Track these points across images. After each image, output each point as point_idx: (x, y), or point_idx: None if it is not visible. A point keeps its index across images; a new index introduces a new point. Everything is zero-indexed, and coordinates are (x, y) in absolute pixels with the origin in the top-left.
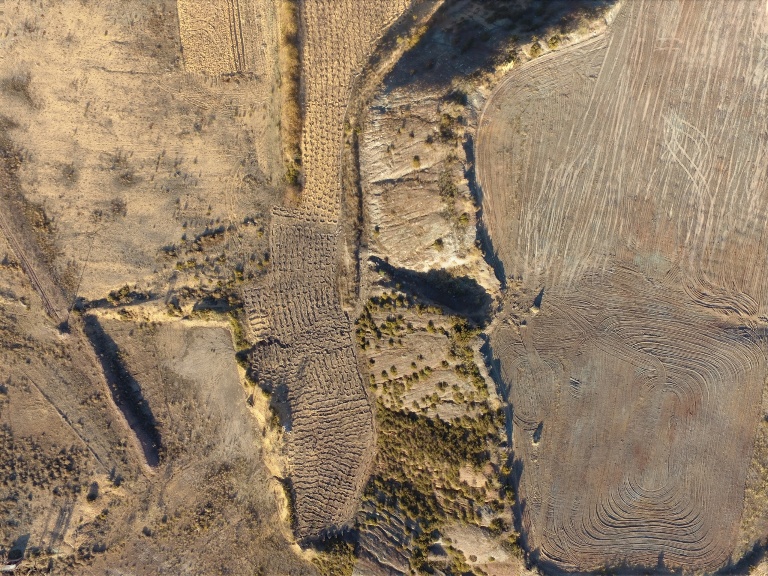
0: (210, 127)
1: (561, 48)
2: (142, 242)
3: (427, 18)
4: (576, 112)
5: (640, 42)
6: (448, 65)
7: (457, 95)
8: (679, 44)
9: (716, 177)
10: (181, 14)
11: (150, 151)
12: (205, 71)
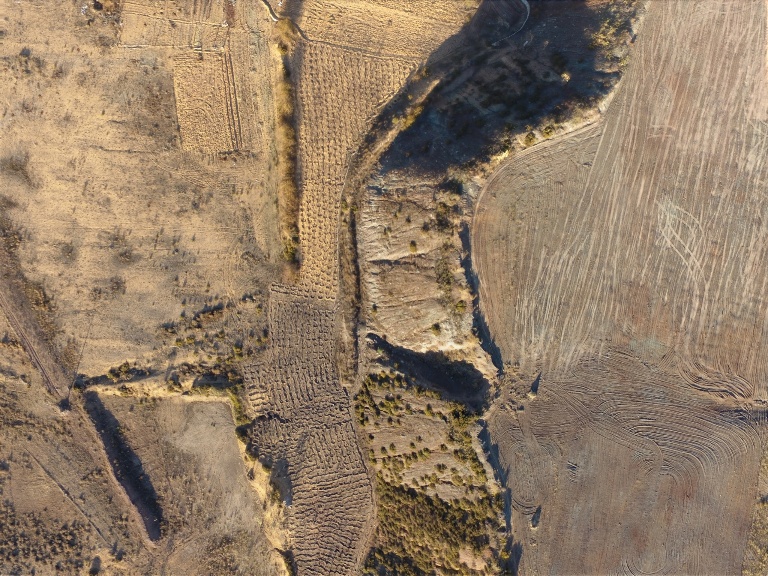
0: (208, 205)
1: (555, 137)
2: (141, 319)
3: (422, 98)
4: (571, 199)
5: (634, 130)
6: (443, 150)
7: (453, 184)
8: (672, 131)
9: (710, 262)
10: (178, 93)
11: (148, 229)
12: (202, 149)
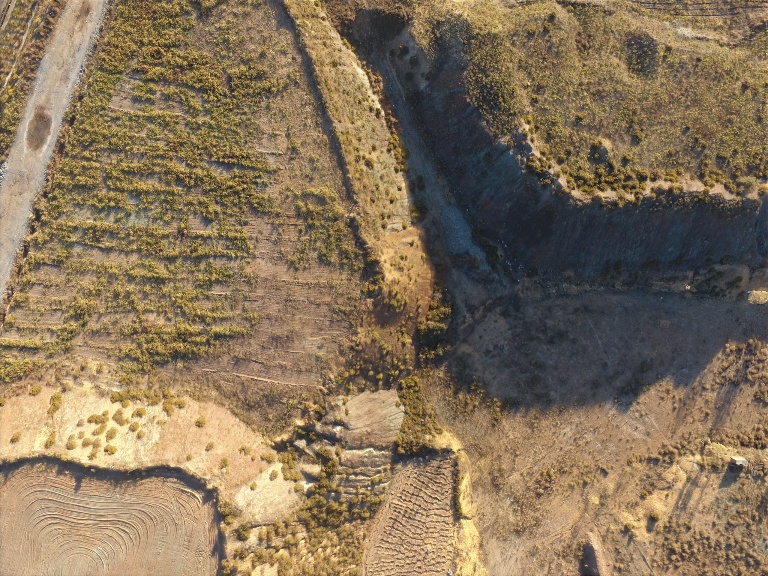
0: None
1: None
2: None
3: None
4: None
5: None
6: None
7: None
8: None
9: None
10: None
11: None
12: None
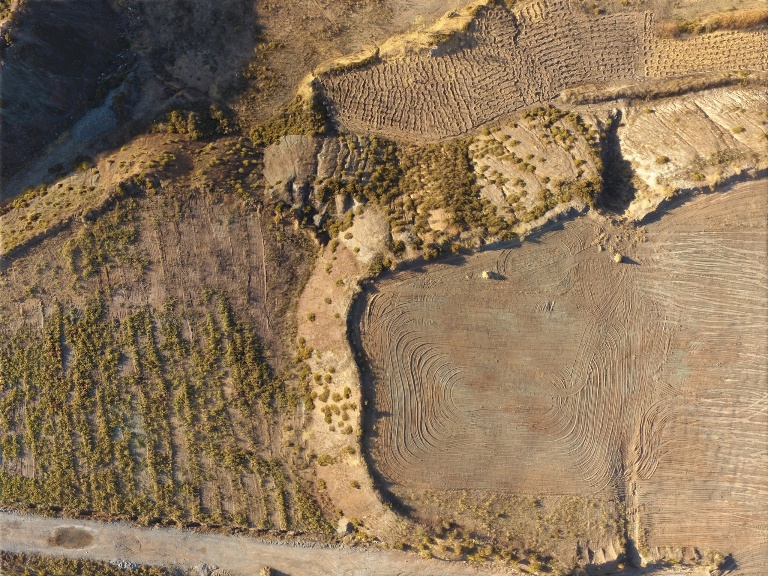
0: None
1: None
2: None
3: None
4: None
5: None
6: None
7: None
8: None
9: None
10: None
11: None
12: None
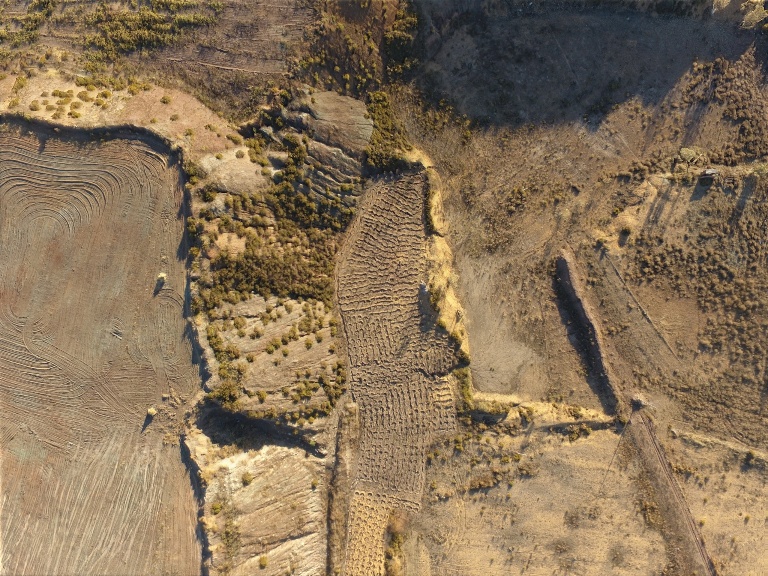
0: None
1: None
2: (552, 485)
3: None
4: None
5: None
6: None
7: None
8: None
9: None
10: None
11: (536, 574)
12: None
